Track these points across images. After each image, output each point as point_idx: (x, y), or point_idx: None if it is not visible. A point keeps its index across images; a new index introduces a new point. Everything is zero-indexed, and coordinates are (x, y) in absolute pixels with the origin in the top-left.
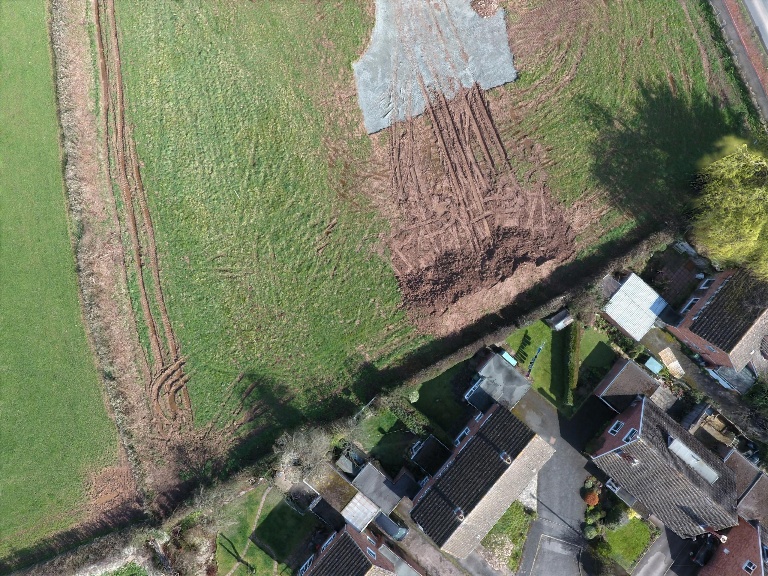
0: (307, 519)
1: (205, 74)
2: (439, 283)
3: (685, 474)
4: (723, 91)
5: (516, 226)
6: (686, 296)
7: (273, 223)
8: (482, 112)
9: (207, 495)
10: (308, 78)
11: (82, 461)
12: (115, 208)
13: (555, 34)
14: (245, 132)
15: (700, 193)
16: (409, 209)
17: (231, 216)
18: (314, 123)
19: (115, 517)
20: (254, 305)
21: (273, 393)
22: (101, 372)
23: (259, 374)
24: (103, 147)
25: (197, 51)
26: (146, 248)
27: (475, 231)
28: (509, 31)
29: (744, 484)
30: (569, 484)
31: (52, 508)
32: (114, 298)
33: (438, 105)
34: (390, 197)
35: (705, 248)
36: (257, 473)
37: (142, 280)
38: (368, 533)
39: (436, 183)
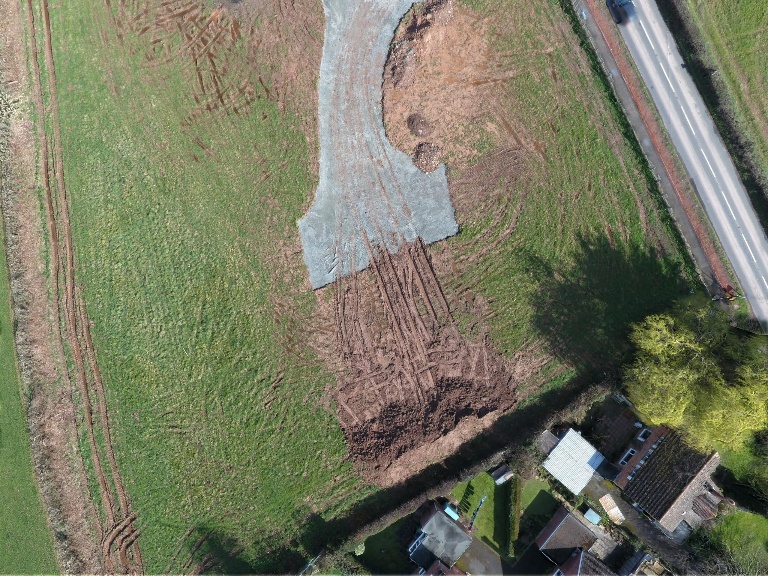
0: None
1: (153, 235)
2: (383, 437)
3: None
4: (659, 242)
5: (459, 376)
6: (625, 444)
7: (221, 379)
8: (425, 266)
9: None
10: (254, 236)
11: None
12: (66, 367)
13: (495, 189)
14: (193, 290)
15: (636, 347)
16: (354, 362)
17: (180, 373)
18: (260, 280)
19: None
20: (203, 460)
21: (222, 546)
22: (53, 530)
23: (208, 528)
24: (54, 308)
25: (145, 212)
26: (97, 406)
27: (419, 382)
28: (450, 186)
29: None
30: None
31: None
32: (65, 457)
33: (382, 260)
34: (335, 351)
35: None
36: None
37: (93, 438)
38: None
39: (380, 336)
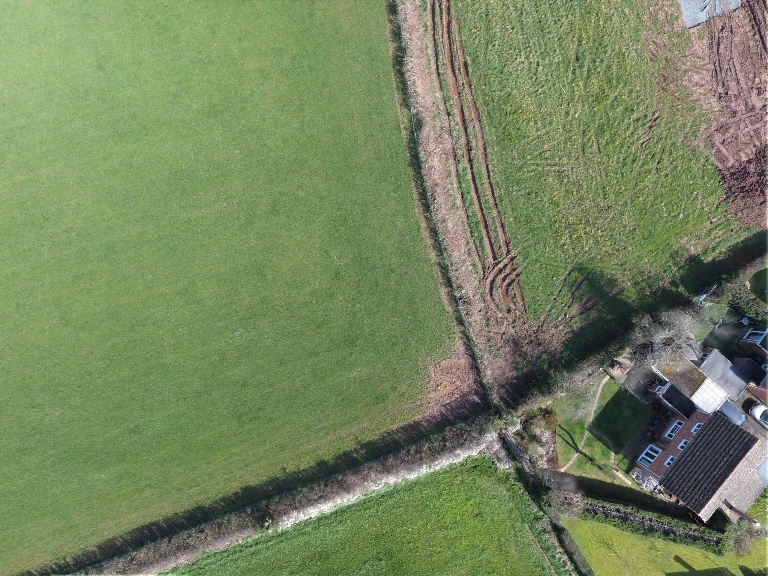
0: (642, 410)
1: None
2: (765, 174)
3: None
4: None
5: None
6: None
7: (597, 117)
8: None
9: (573, 378)
10: None
11: (422, 354)
12: (443, 103)
13: None
14: (568, 26)
15: None
16: (729, 102)
17: (557, 110)
18: (635, 17)
19: (454, 410)
20: (582, 199)
21: (602, 286)
22: (437, 266)
23: (588, 267)
24: (430, 42)
25: None
26: (475, 143)
27: None
28: None
29: None
30: None
31: (395, 401)
32: (447, 192)
33: None
34: (711, 91)
35: None
36: (605, 361)
37: (472, 175)
38: None
39: (755, 76)
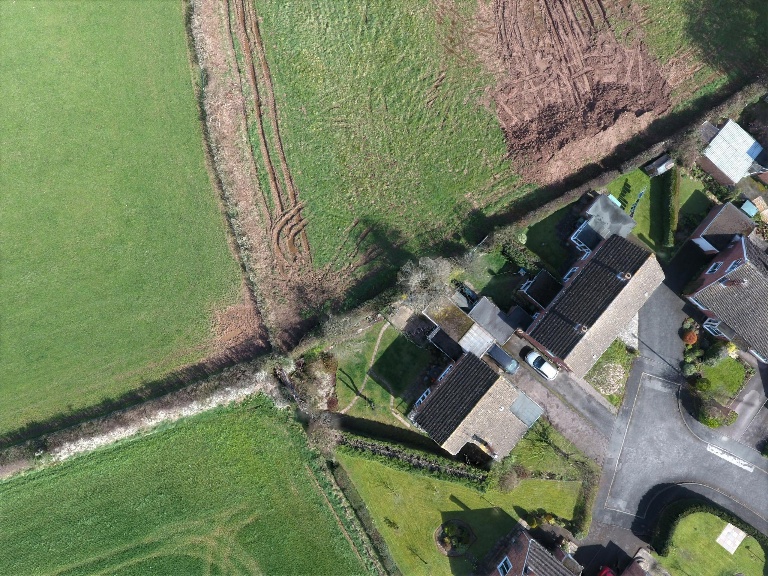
0: (421, 356)
1: None
2: (544, 132)
3: None
4: None
5: (614, 82)
6: None
7: (385, 76)
8: None
9: (336, 319)
10: None
11: (208, 299)
12: (235, 61)
13: None
14: None
15: None
16: (513, 64)
17: (345, 69)
18: None
19: (239, 353)
20: (368, 154)
21: (387, 237)
22: (225, 215)
23: (373, 219)
24: (223, 3)
25: None
26: (265, 99)
27: (576, 86)
28: None
29: None
30: (668, 325)
31: (180, 343)
32: (236, 145)
33: None
34: (495, 53)
35: None
36: (378, 306)
37: (262, 129)
38: None
39: (539, 40)
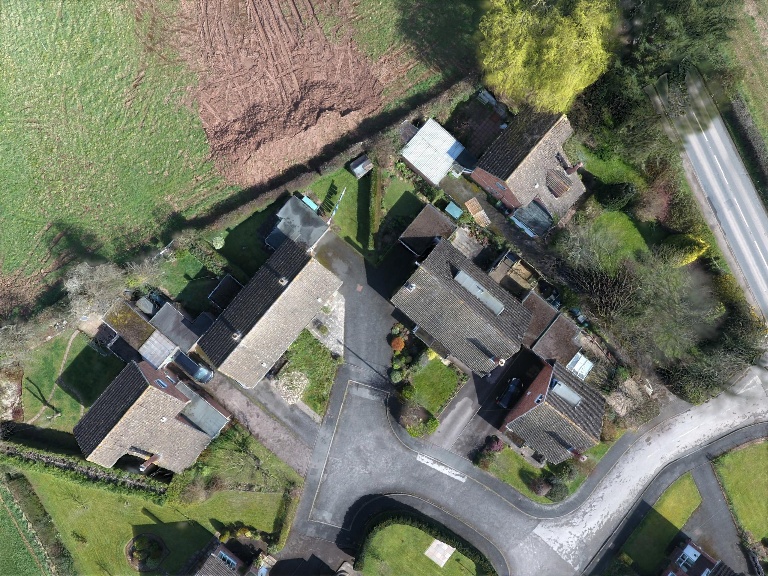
0: (113, 364)
1: None
2: (244, 133)
3: (467, 302)
4: None
5: (324, 80)
6: None
7: (81, 76)
8: None
9: None
10: None
11: None
12: None
13: None
14: None
15: None
16: (217, 63)
17: (38, 68)
18: None
19: None
20: (62, 155)
21: (81, 242)
22: None
23: (67, 223)
24: None
25: None
26: None
27: (283, 84)
28: None
29: (542, 324)
30: (376, 331)
31: None
32: None
33: None
34: (198, 51)
35: (496, 89)
36: (56, 313)
37: None
38: (171, 375)
39: (244, 37)
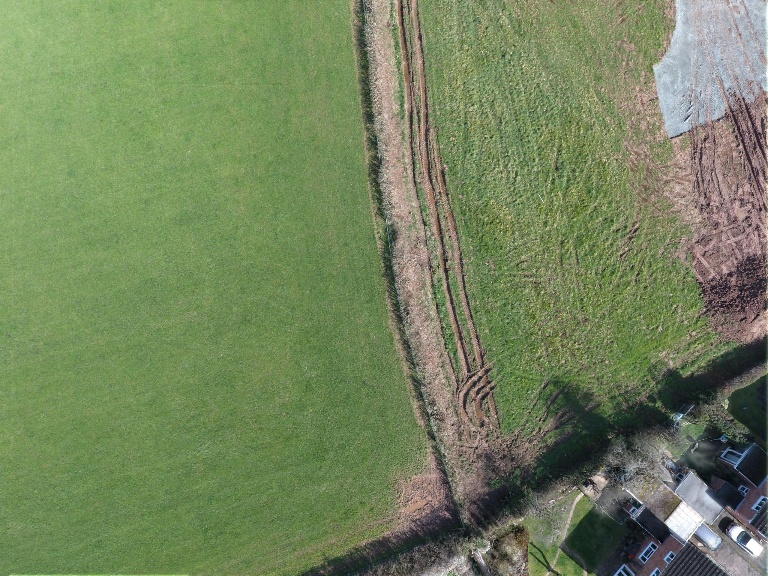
0: (617, 528)
1: (509, 77)
2: (746, 289)
3: None
4: None
5: None
6: None
7: (576, 228)
8: None
9: (544, 504)
10: (610, 81)
11: (392, 469)
12: (419, 212)
13: None
14: (548, 136)
15: None
16: (711, 214)
17: (535, 221)
18: (616, 127)
19: (424, 526)
20: (559, 311)
21: (578, 400)
22: (410, 378)
23: (564, 381)
24: (407, 150)
25: (500, 53)
26: (451, 253)
27: None
28: None
29: None
30: None
31: (364, 516)
32: (421, 303)
33: (738, 109)
34: (692, 202)
35: None
36: (578, 482)
37: (447, 285)
38: None
39: (738, 188)
